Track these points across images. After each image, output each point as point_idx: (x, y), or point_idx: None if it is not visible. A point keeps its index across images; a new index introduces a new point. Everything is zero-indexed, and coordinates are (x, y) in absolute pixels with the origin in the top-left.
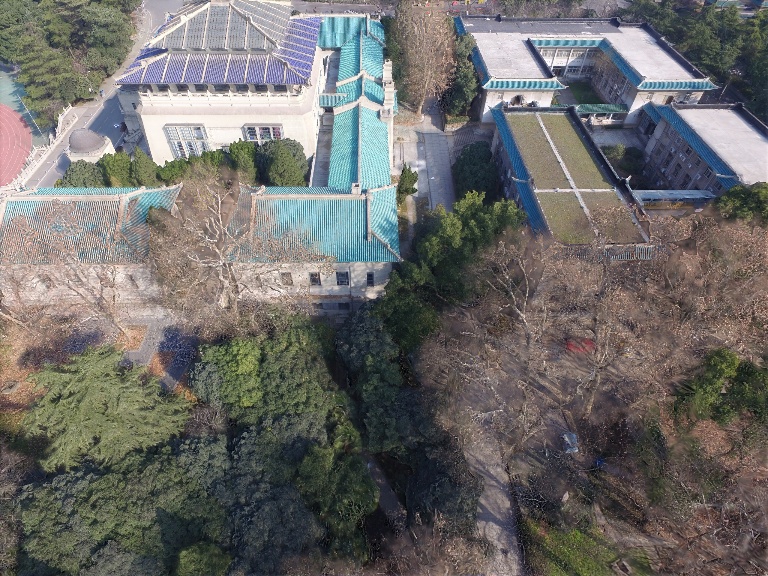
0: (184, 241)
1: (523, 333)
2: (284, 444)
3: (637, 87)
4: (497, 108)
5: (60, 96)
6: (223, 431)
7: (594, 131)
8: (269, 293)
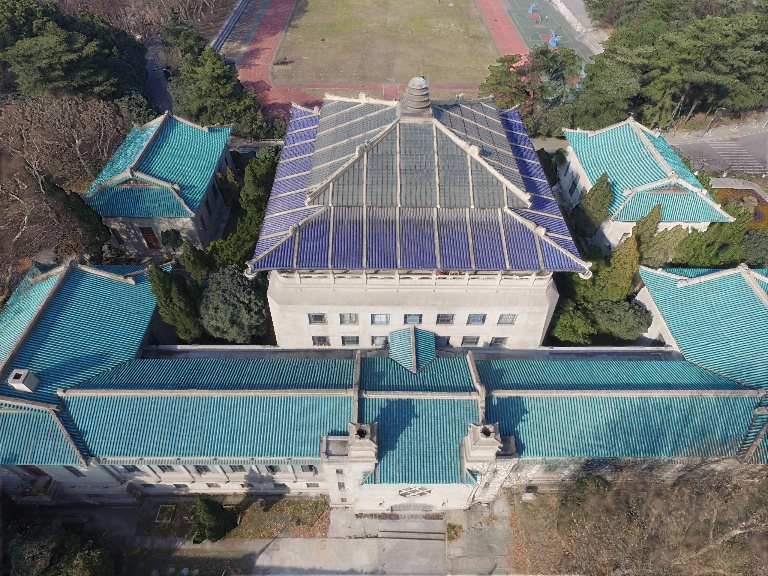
0: None
1: None
2: None
3: None
4: None
5: None
6: None
7: None
8: None
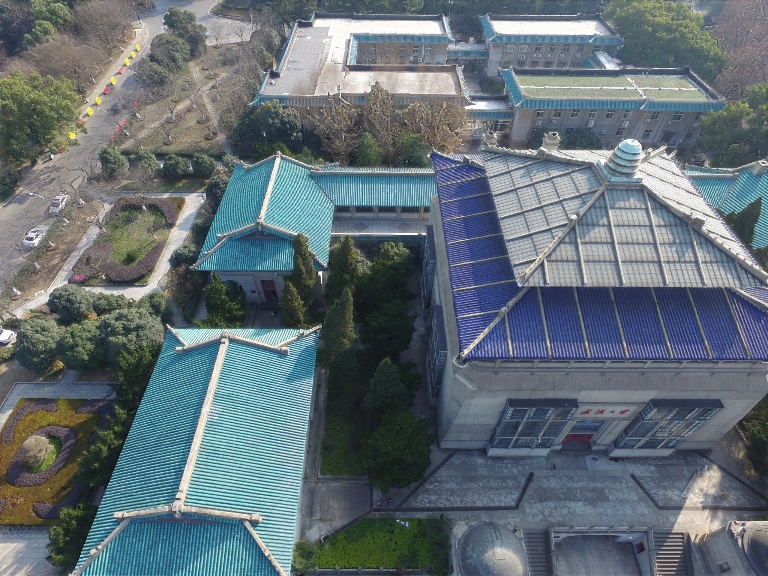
0: None
1: None
2: None
3: None
4: (522, 101)
5: None
6: None
7: None
8: None
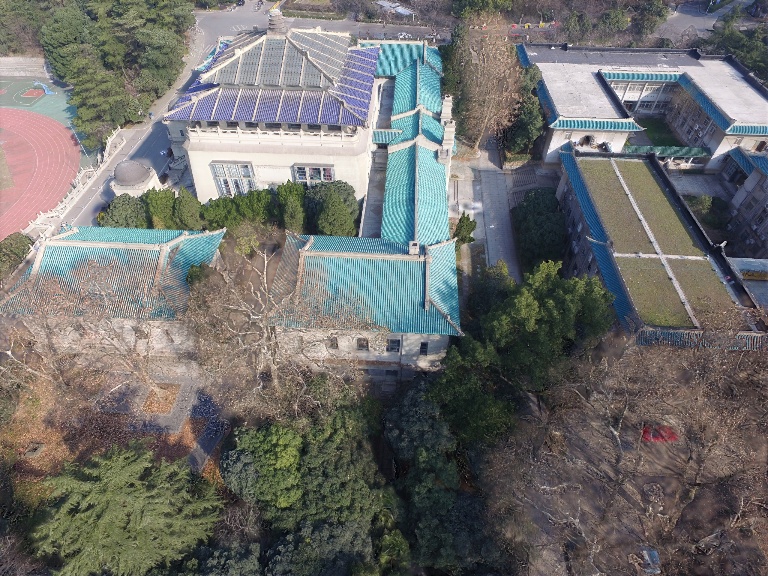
0: (225, 299)
1: (591, 413)
2: (324, 559)
3: (725, 131)
4: (567, 152)
5: (110, 119)
6: (256, 538)
7: (670, 176)
8: (311, 355)
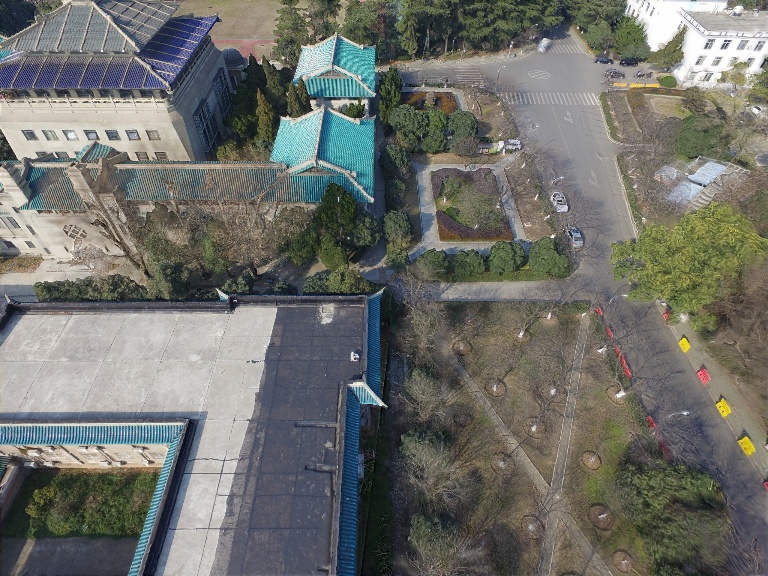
0: None
1: None
2: None
3: None
4: None
5: None
6: None
7: None
8: None
